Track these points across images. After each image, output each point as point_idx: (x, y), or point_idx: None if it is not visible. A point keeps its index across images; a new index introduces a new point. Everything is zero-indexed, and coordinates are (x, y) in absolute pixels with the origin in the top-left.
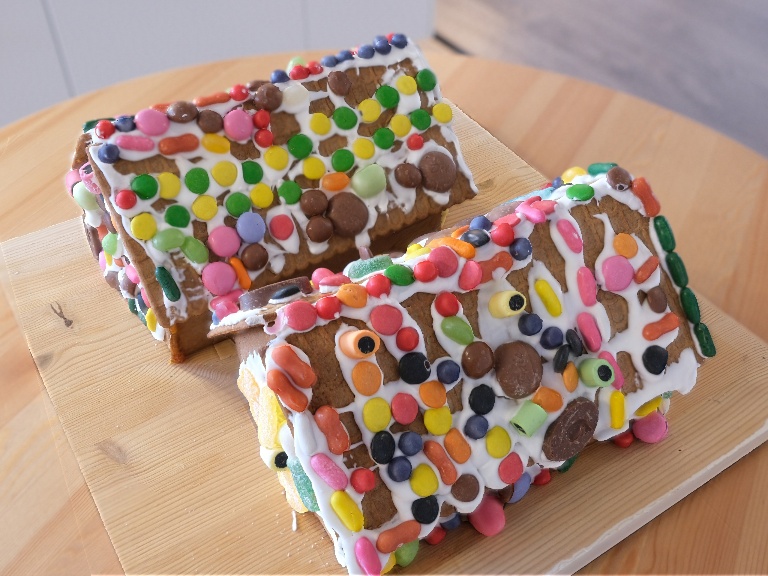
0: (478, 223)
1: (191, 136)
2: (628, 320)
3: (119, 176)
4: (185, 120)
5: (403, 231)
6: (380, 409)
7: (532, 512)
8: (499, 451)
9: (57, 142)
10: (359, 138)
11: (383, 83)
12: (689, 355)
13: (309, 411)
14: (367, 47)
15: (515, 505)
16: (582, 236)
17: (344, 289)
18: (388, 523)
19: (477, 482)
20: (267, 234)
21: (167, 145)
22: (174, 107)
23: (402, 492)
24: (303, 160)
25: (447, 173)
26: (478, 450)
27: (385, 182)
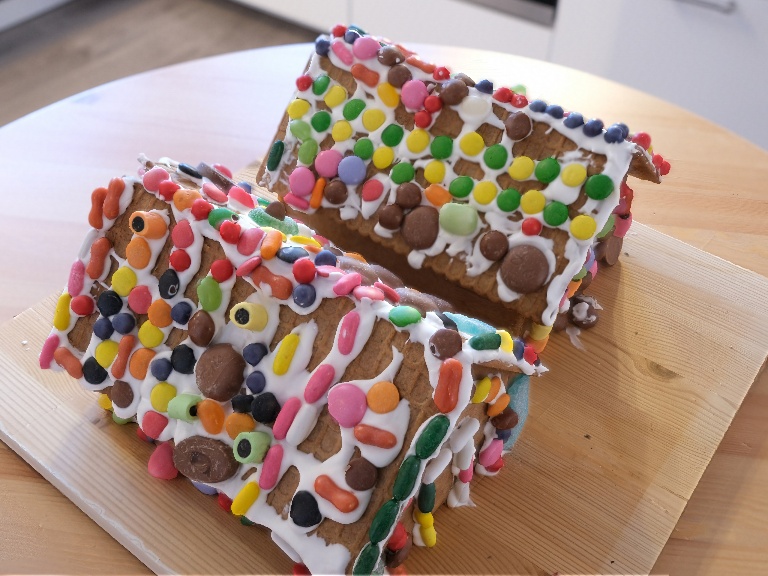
0: (320, 252)
1: (376, 75)
2: (330, 457)
3: (318, 66)
4: (381, 61)
5: (465, 291)
6: (125, 278)
7: (193, 507)
8: (155, 400)
9: (501, 82)
10: (492, 182)
11: (561, 158)
12: (341, 554)
13: (105, 235)
14: (575, 116)
15: (198, 491)
16: (367, 349)
17: (188, 190)
18: (78, 351)
19: (131, 400)
20: (362, 186)
21: (355, 68)
22: (385, 47)
23: (92, 341)
24: (435, 159)
25: (523, 274)
26: (147, 381)
27: (471, 232)
